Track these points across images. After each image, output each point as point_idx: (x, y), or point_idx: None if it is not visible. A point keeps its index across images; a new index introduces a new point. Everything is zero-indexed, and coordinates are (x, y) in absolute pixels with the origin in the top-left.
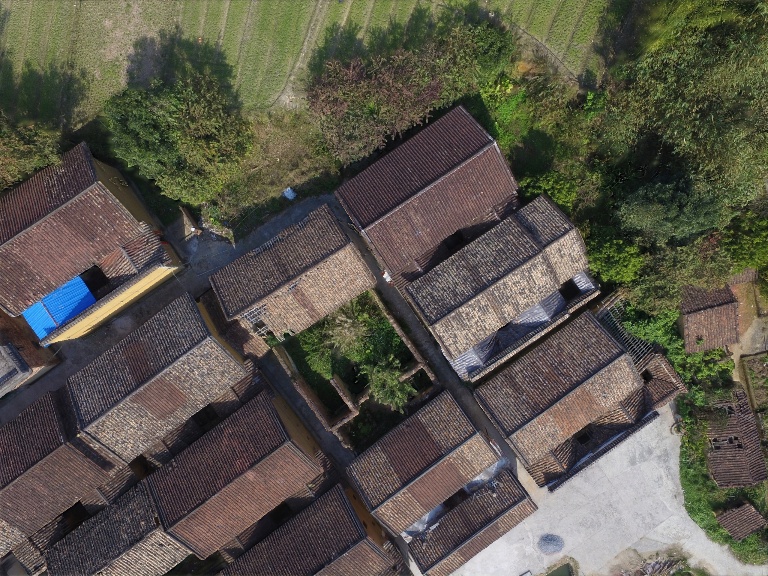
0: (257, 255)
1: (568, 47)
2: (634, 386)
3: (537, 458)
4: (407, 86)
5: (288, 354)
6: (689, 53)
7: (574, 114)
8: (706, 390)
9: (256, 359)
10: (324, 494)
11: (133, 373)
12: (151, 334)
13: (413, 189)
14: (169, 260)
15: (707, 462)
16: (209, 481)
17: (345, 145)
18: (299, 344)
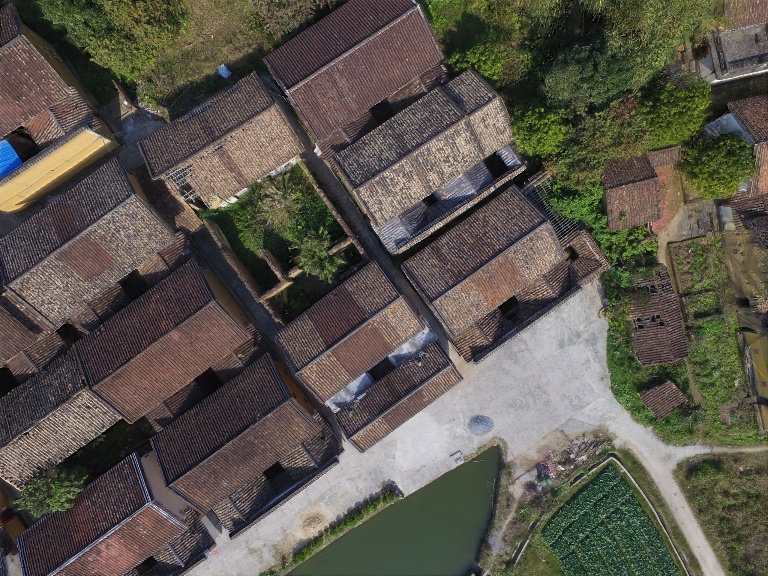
0: (185, 121)
1: None
2: (557, 259)
3: (462, 329)
4: None
5: (222, 232)
6: None
7: None
8: (630, 270)
9: (188, 233)
10: (253, 363)
11: (59, 232)
12: (78, 197)
13: (338, 52)
14: (98, 126)
15: (632, 344)
16: (135, 342)
17: (274, 14)
18: (233, 222)
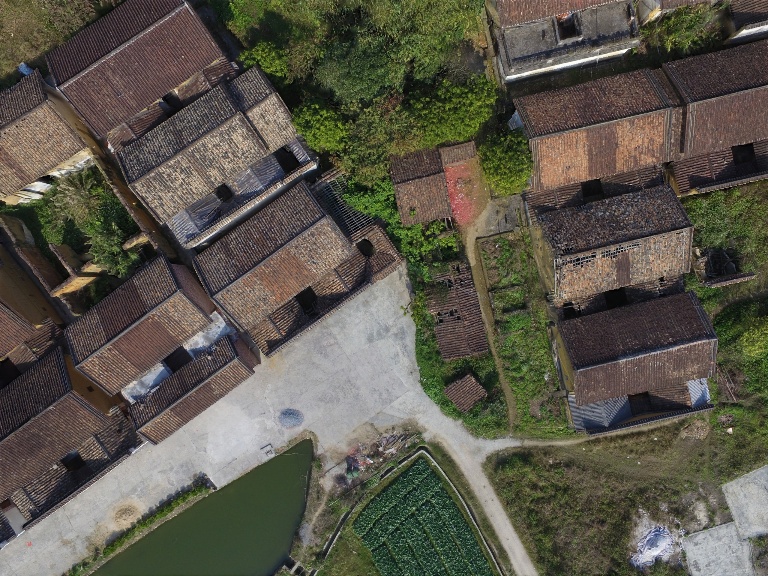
0: None
1: None
2: (345, 254)
3: (252, 323)
4: None
5: (27, 228)
6: None
7: None
8: (429, 265)
9: None
10: (45, 356)
11: None
12: None
13: (109, 49)
14: None
15: None
16: None
17: (58, 12)
18: (37, 218)
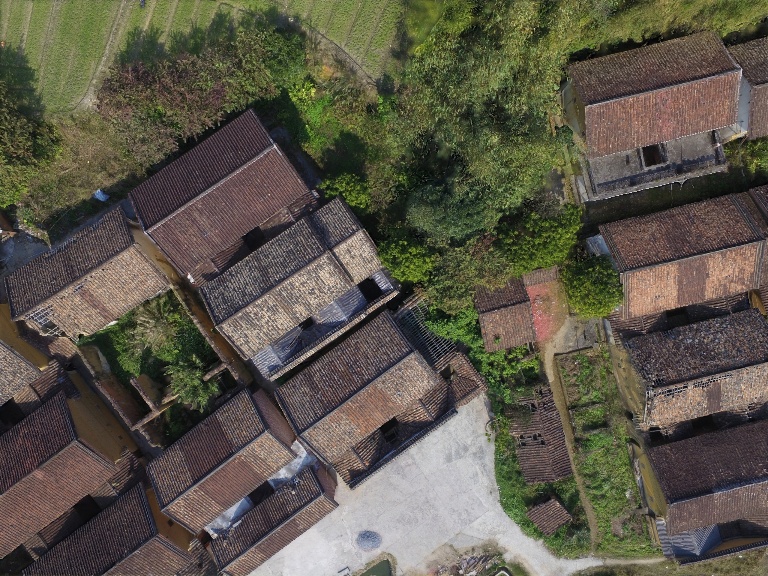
0: (51, 256)
1: (366, 52)
2: (430, 384)
3: (336, 456)
4: (191, 90)
5: (102, 354)
6: (447, 58)
7: (371, 117)
8: (511, 388)
9: (65, 359)
10: (126, 493)
11: None
12: None
13: (196, 191)
14: None
15: None
16: None
17: None
18: (112, 344)
